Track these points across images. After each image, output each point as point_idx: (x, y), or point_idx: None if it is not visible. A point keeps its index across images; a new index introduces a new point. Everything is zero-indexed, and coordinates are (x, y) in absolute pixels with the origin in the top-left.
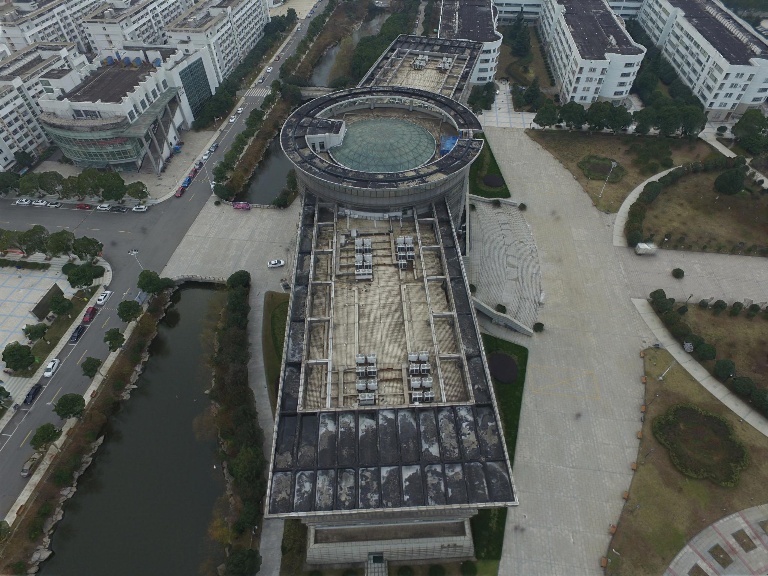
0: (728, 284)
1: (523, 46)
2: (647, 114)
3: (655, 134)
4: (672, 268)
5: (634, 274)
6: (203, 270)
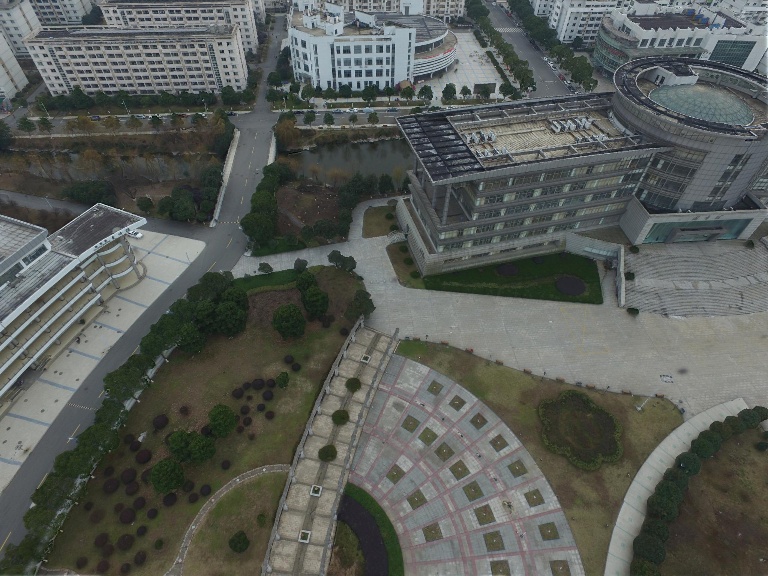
0: None
1: None
2: None
3: None
4: None
5: None
6: None
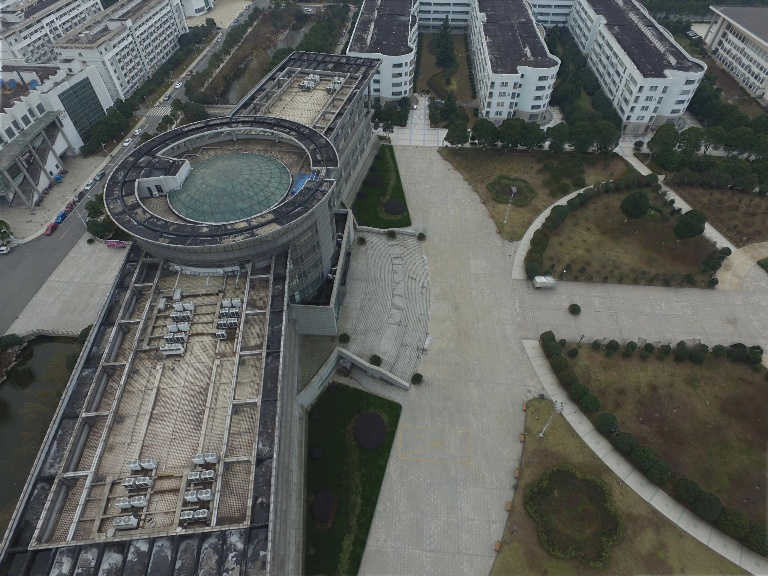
0: (626, 319)
1: (447, 56)
2: (559, 131)
3: (571, 150)
4: (570, 303)
5: (529, 311)
6: (58, 322)
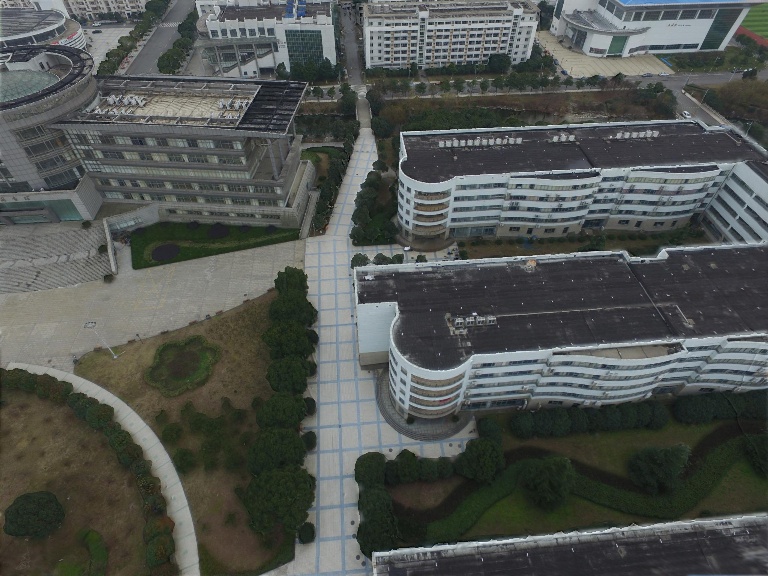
0: None
1: None
2: (269, 403)
3: None
4: None
5: None
6: None
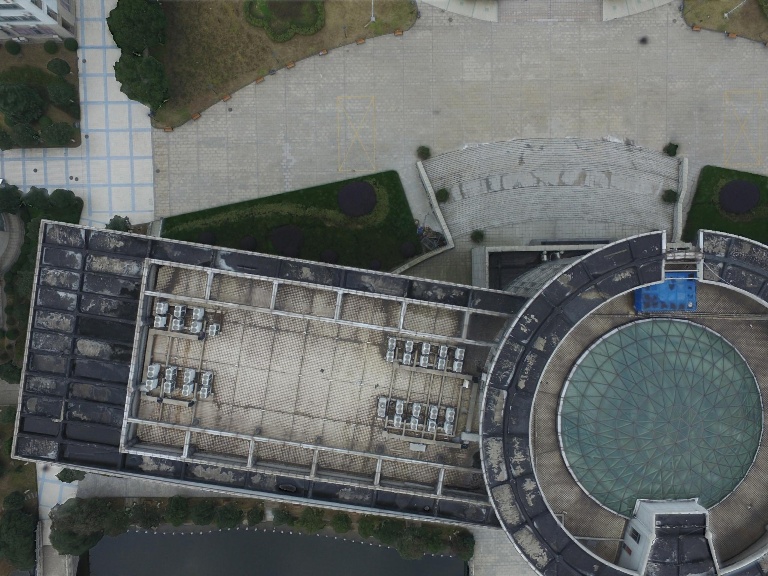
0: None
1: None
2: None
3: None
4: None
5: (556, 5)
6: None
